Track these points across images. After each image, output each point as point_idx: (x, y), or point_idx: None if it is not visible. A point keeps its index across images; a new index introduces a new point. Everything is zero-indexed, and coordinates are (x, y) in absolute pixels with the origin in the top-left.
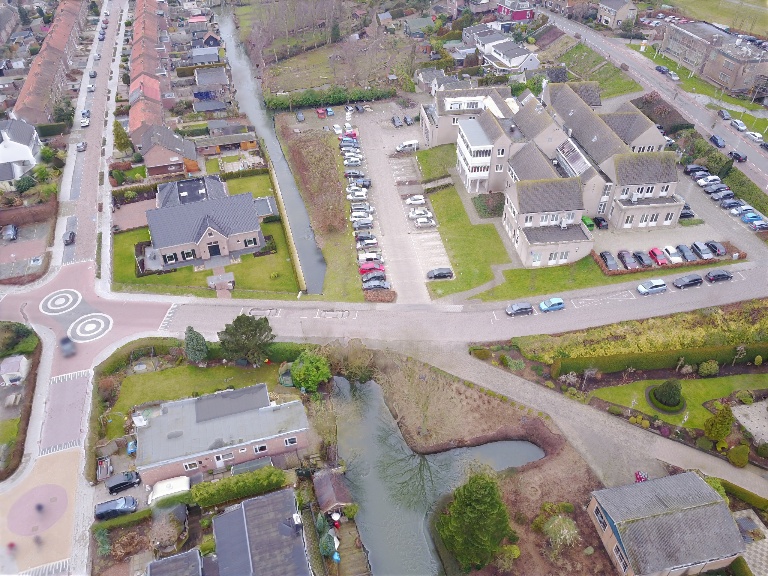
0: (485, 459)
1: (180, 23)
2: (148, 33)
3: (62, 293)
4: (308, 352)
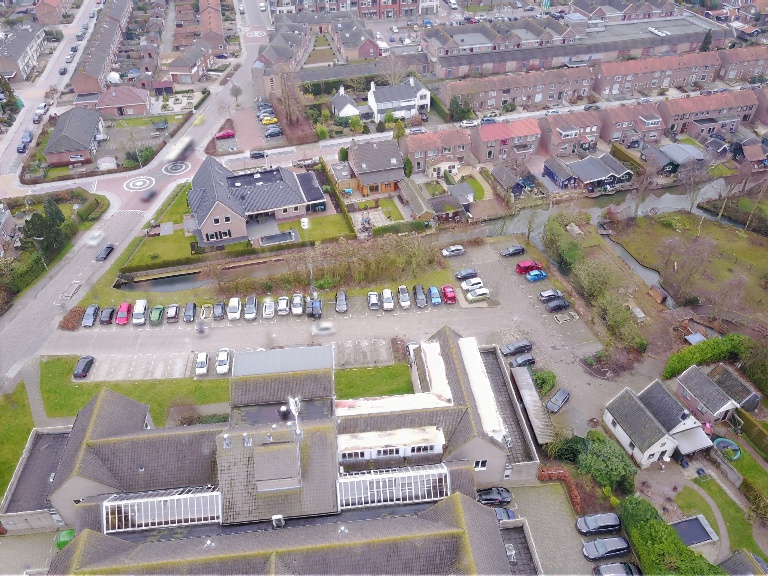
0: None
1: None
2: (681, 103)
3: (186, 166)
4: (5, 265)
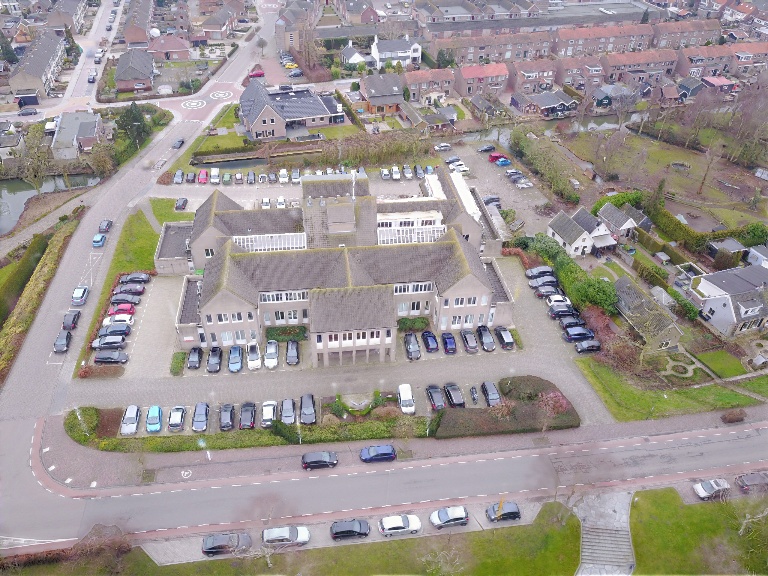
0: (8, 220)
1: None
2: (618, 57)
3: (229, 94)
4: None
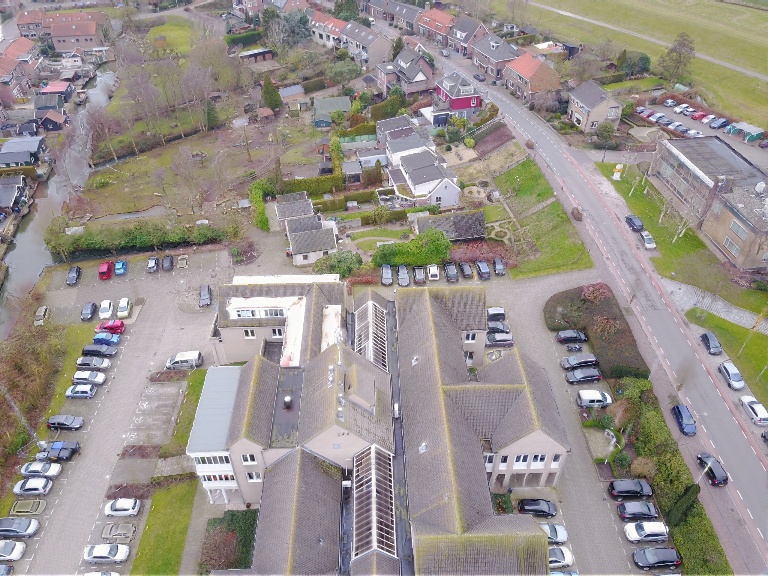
0: None
1: (38, 91)
2: None
3: None
4: None
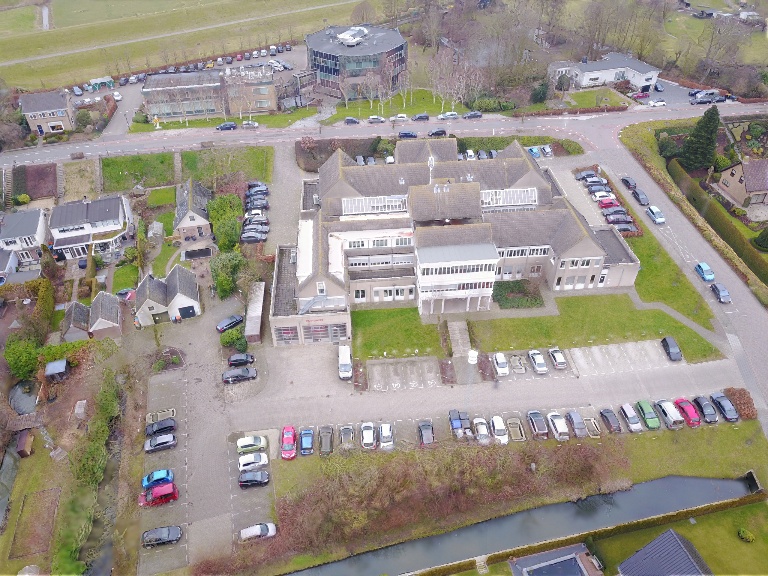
0: None
1: None
2: None
3: None
4: None
